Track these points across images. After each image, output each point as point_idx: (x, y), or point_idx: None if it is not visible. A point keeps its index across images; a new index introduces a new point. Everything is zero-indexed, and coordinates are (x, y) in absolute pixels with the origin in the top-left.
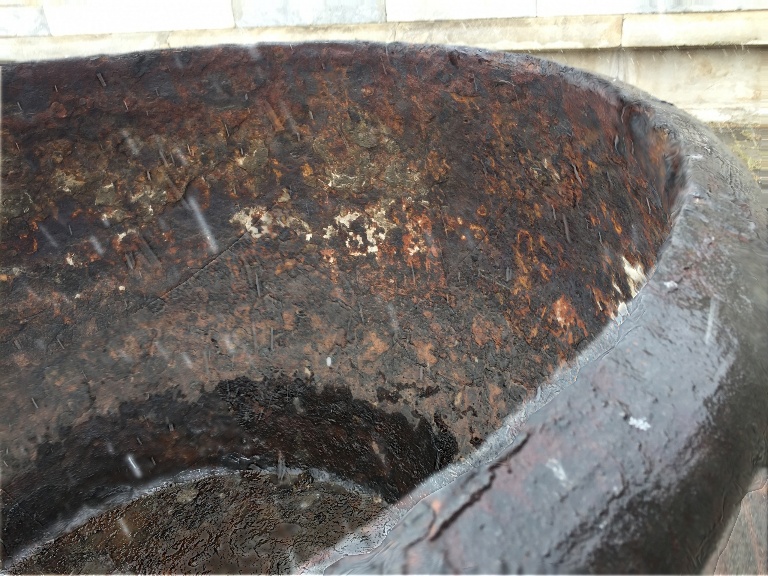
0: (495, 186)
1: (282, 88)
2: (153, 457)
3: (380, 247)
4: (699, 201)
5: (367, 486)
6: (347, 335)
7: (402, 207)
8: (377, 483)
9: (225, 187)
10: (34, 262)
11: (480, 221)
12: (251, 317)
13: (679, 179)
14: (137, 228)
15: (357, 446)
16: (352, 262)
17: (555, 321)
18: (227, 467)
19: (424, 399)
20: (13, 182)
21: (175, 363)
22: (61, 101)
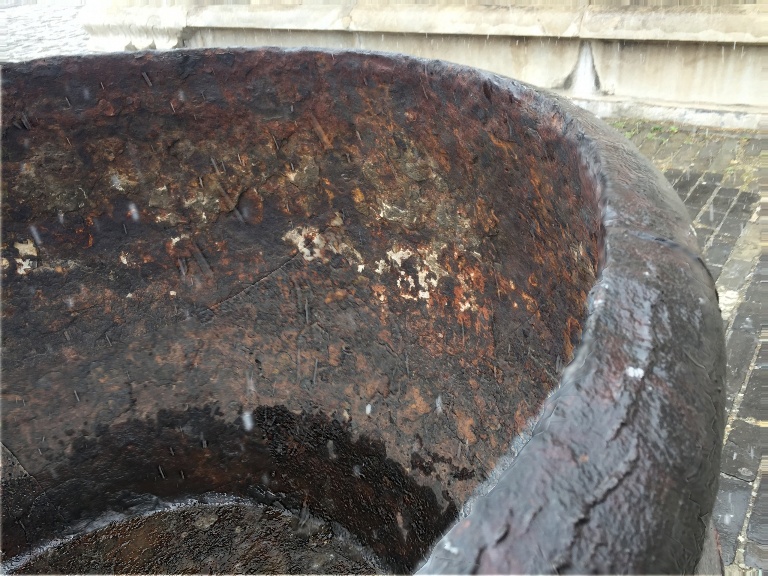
0: (543, 255)
1: (327, 102)
2: (183, 471)
3: (432, 294)
4: (441, 573)
5: (385, 560)
6: (390, 384)
7: (454, 254)
8: (395, 561)
9: (278, 202)
10: (89, 257)
11: (532, 291)
12: (297, 344)
13: None
14: (191, 234)
15: (383, 512)
16: (403, 305)
17: None
18: (252, 498)
19: (457, 481)
20: (67, 176)
21: (218, 378)
22: (108, 99)
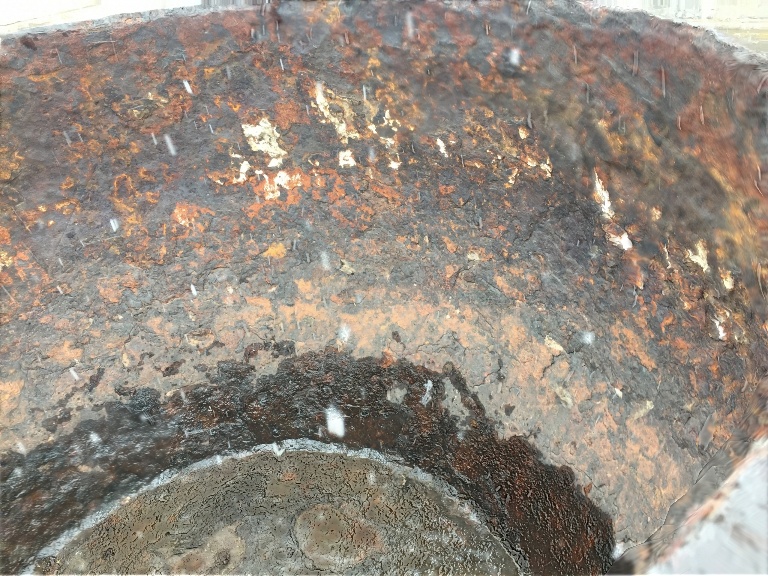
0: (82, 150)
1: None
2: None
3: None
4: None
5: (105, 505)
6: None
7: None
8: (112, 492)
9: None
10: None
11: (67, 195)
12: None
13: (367, 1)
14: None
15: (65, 488)
16: None
17: (179, 227)
18: None
19: (95, 389)
20: None
21: None
22: None
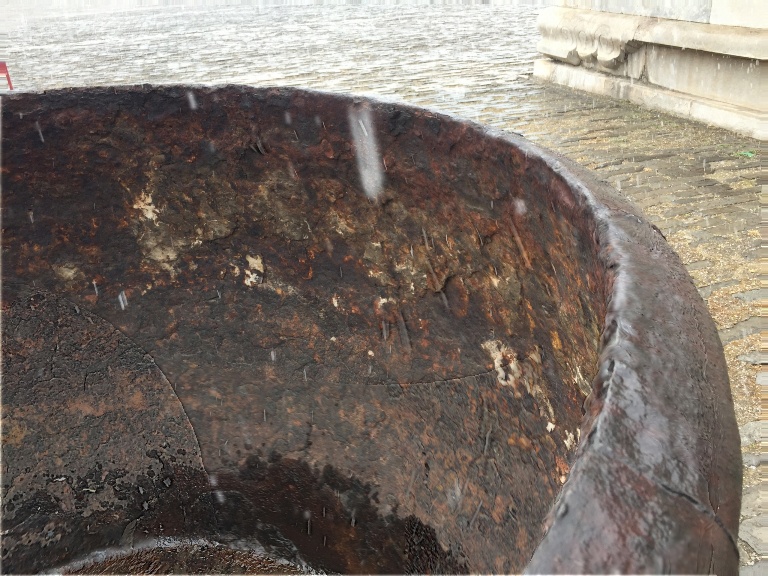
0: None
1: (523, 212)
2: (326, 537)
3: None
4: None
5: None
6: None
7: None
8: None
9: (483, 303)
10: (307, 288)
11: None
12: (469, 470)
13: None
14: (398, 300)
15: None
16: None
17: None
18: None
19: None
20: (295, 207)
21: (387, 461)
22: (329, 140)
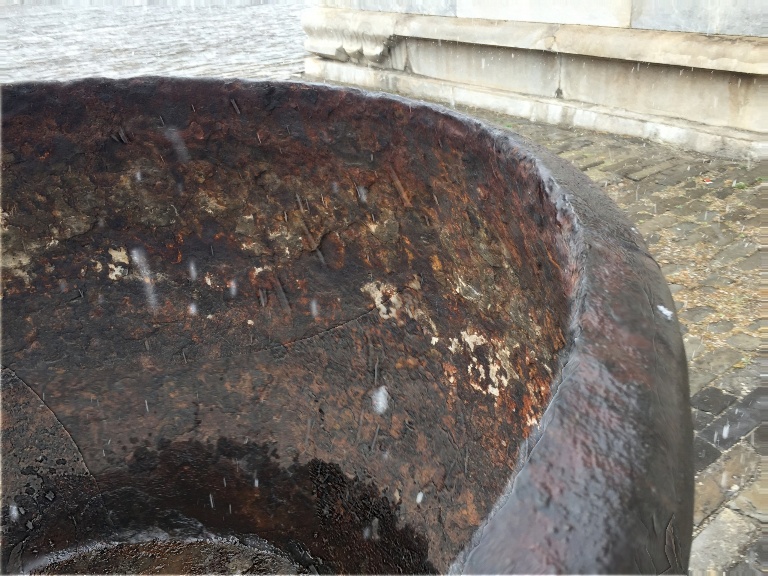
0: None
1: (405, 157)
2: (231, 505)
3: (501, 393)
4: None
5: None
6: (446, 478)
7: (525, 358)
8: None
9: (359, 251)
10: (177, 272)
11: None
12: (362, 403)
13: None
14: (273, 266)
15: None
16: (471, 394)
17: None
18: (291, 553)
19: None
20: (160, 192)
21: (281, 418)
22: (199, 122)
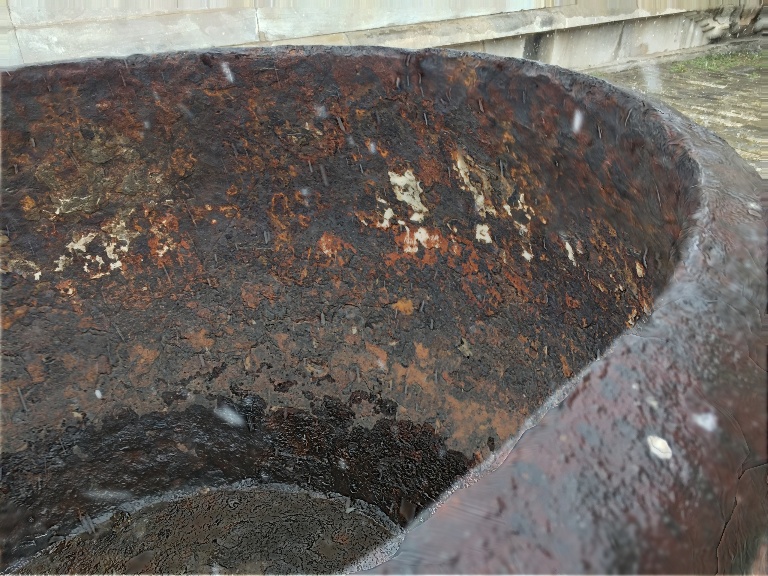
0: (247, 163)
1: None
2: None
3: (124, 260)
4: None
5: (188, 487)
6: (110, 360)
7: (144, 213)
8: (197, 478)
9: None
10: None
11: (231, 200)
12: None
13: (501, 69)
14: None
15: (161, 458)
16: (95, 286)
17: (322, 255)
18: (23, 557)
19: (214, 380)
20: None
21: None
22: None
